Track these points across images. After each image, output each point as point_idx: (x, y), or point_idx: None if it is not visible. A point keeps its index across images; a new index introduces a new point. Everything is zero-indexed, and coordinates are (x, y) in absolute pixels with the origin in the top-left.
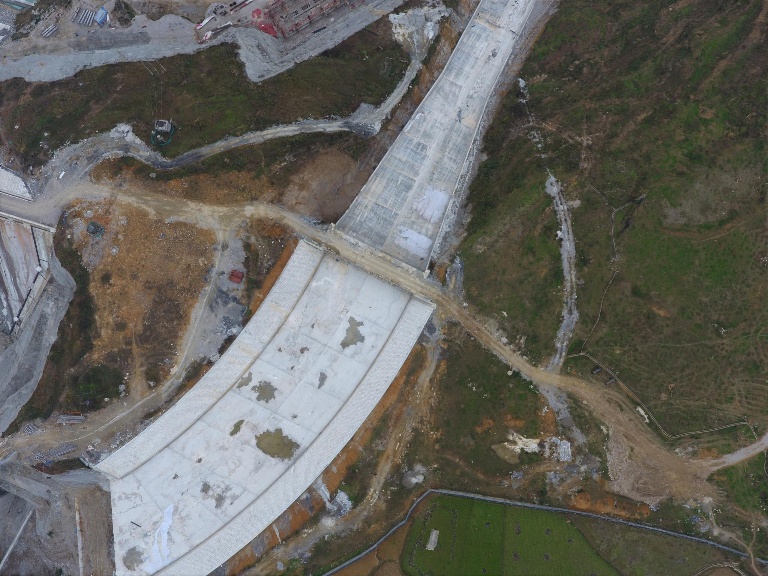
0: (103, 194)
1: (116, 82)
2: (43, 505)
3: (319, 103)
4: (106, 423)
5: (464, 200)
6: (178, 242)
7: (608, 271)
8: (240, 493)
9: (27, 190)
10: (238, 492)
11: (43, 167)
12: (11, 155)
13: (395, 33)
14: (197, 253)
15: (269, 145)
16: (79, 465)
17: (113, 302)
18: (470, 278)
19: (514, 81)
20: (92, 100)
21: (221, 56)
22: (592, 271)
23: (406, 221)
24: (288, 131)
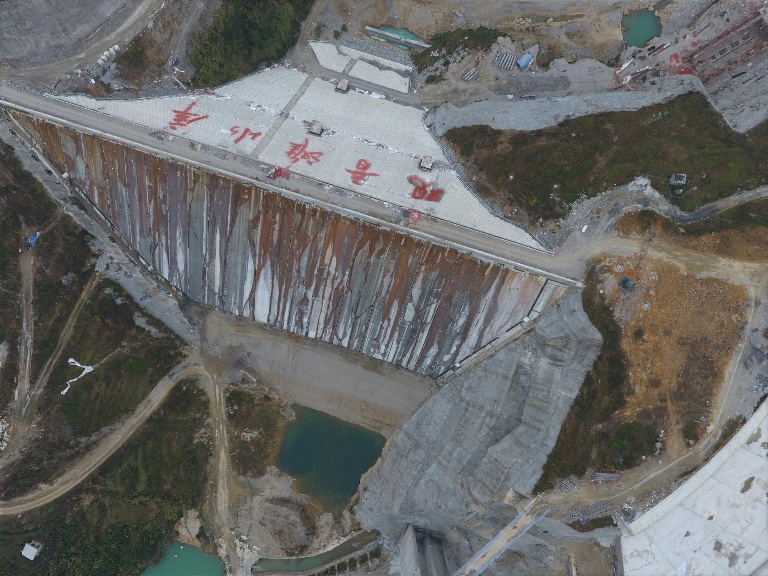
0: (633, 249)
1: (610, 133)
2: (506, 556)
3: None
4: (640, 481)
5: None
6: (711, 298)
7: None
8: (753, 552)
9: (537, 242)
10: (751, 551)
11: (563, 220)
12: (514, 206)
13: None
14: (730, 309)
15: None
16: (611, 523)
17: (646, 358)
18: None
19: None
20: (596, 152)
21: (696, 106)
22: None
23: None
24: None
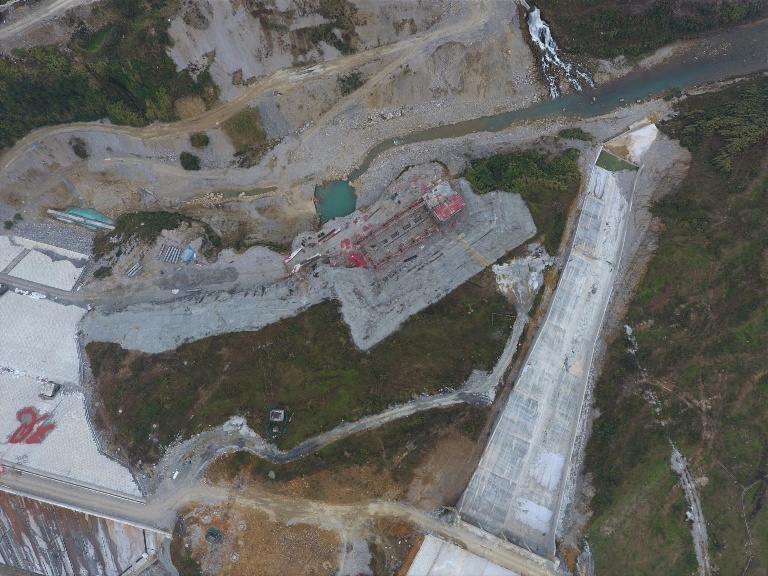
0: (221, 497)
1: (222, 360)
2: None
3: (430, 371)
4: None
5: (581, 465)
6: (301, 546)
7: (742, 556)
8: None
9: (136, 486)
10: None
11: (155, 466)
12: (117, 445)
13: (499, 284)
14: (321, 557)
15: (387, 430)
16: None
17: None
18: (601, 566)
19: (620, 328)
20: (200, 385)
21: (325, 319)
22: (726, 557)
23: (524, 491)
24: (404, 411)
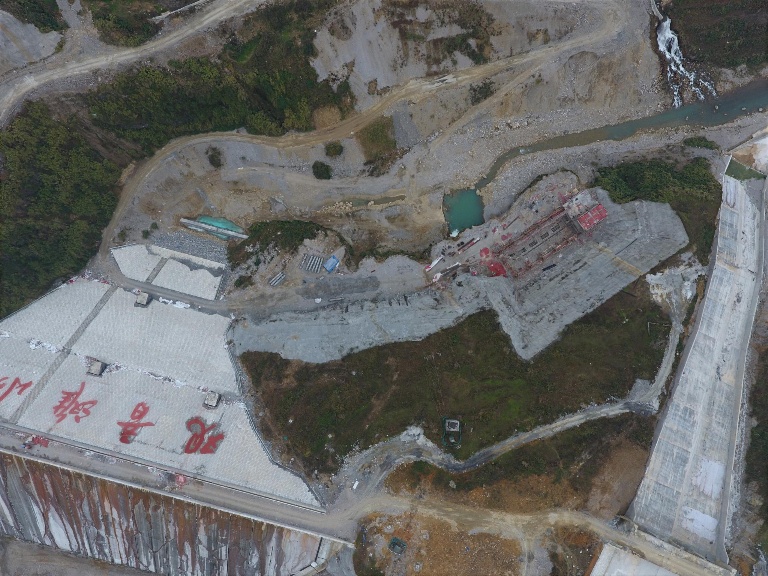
0: (403, 507)
1: (390, 370)
2: None
3: (594, 381)
4: None
5: (743, 473)
6: (483, 555)
7: None
8: None
9: (313, 495)
10: None
11: (334, 476)
12: (290, 455)
13: (653, 294)
14: (503, 566)
15: (560, 440)
16: None
17: None
18: None
19: None
20: (373, 395)
21: (485, 329)
22: None
23: (689, 500)
24: (575, 421)
